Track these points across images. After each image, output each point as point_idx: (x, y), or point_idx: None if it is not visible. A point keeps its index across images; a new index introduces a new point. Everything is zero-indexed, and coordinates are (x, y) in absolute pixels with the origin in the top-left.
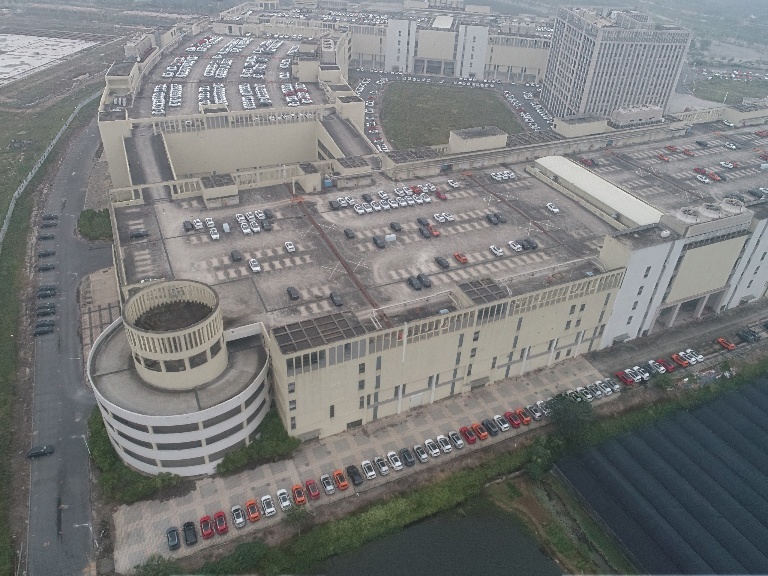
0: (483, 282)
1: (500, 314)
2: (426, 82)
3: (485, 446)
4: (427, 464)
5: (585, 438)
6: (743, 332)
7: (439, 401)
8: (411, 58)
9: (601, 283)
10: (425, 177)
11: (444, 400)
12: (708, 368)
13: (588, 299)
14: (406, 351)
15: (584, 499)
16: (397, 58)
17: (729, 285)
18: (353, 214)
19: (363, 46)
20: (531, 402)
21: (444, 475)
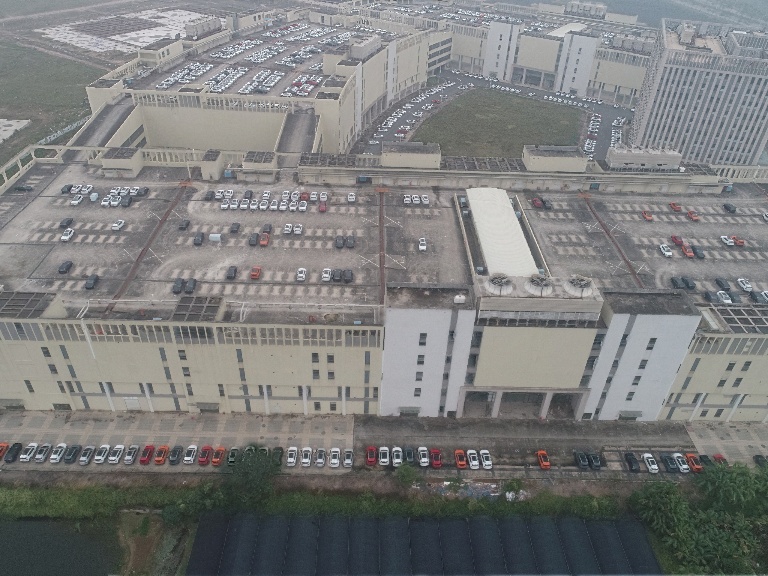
0: (211, 300)
1: (206, 338)
2: (514, 93)
3: (153, 471)
4: (84, 467)
5: (265, 503)
6: (581, 453)
7: (161, 412)
8: (510, 65)
9: (350, 336)
10: (334, 186)
11: (167, 413)
12: (490, 480)
13: (336, 351)
14: (94, 348)
15: (187, 564)
16: (496, 64)
17: (587, 388)
18: (217, 208)
19: (463, 48)
20: (246, 445)
21: (85, 484)
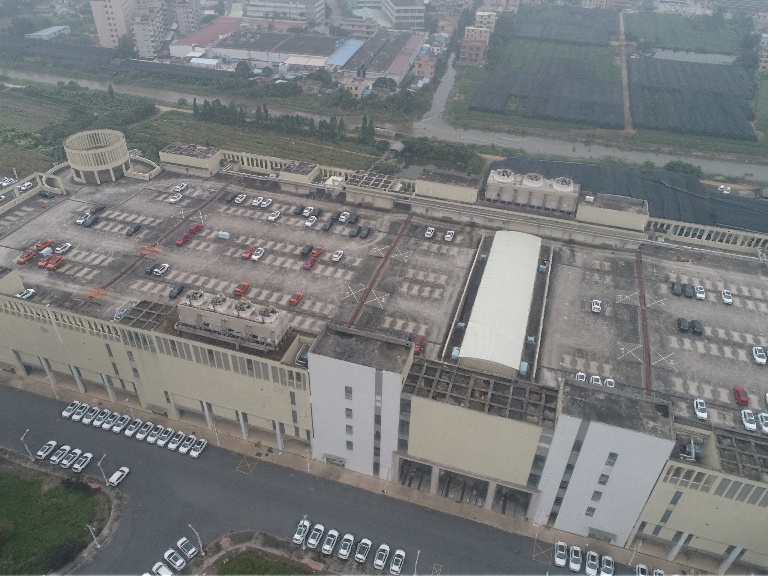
0: None
1: None
2: None
3: None
4: None
5: None
6: None
7: None
8: None
9: None
10: None
11: None
12: None
13: None
14: None
15: None
16: None
17: None
18: None
19: None
20: None
21: None
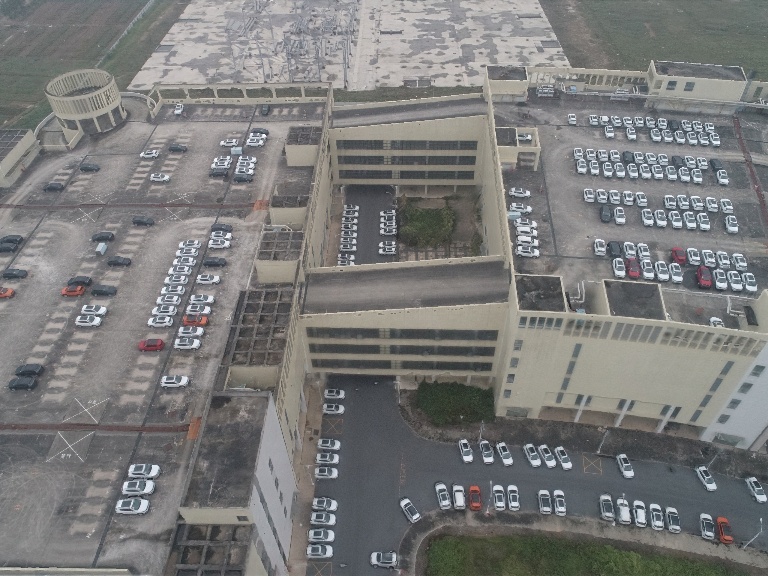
0: None
1: None
2: None
3: None
4: None
5: None
6: None
7: None
8: None
9: None
10: None
11: None
12: None
13: None
14: None
15: None
16: None
17: None
18: None
19: None
20: None
21: None
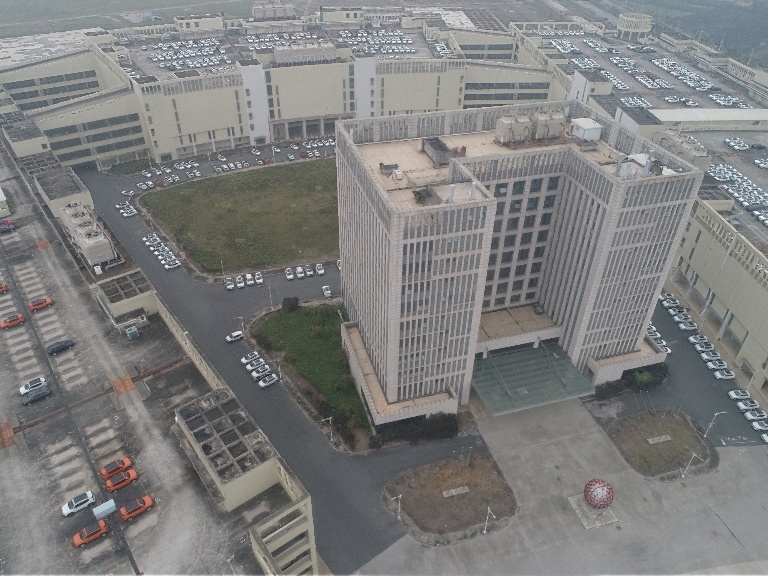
0: None
1: None
2: None
3: None
4: None
5: None
6: None
7: None
8: None
9: None
10: None
11: None
12: None
13: None
14: None
15: None
16: None
17: None
18: None
19: (556, 99)
20: None
21: None
